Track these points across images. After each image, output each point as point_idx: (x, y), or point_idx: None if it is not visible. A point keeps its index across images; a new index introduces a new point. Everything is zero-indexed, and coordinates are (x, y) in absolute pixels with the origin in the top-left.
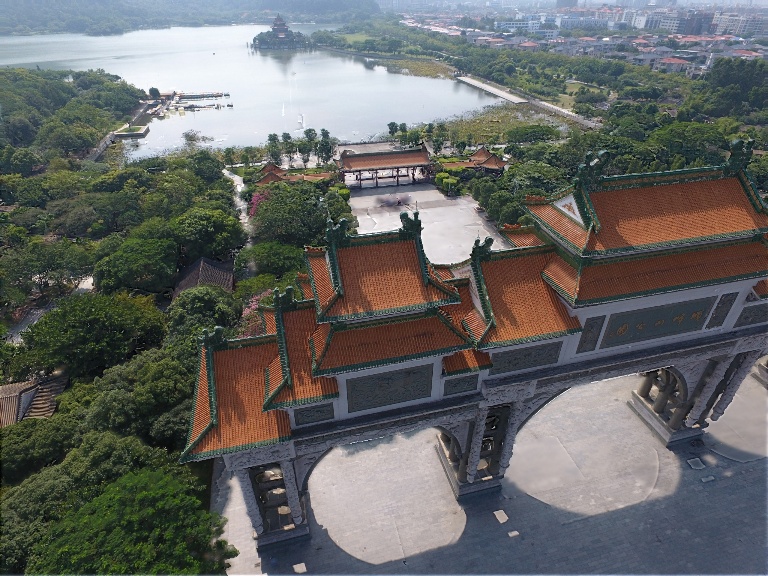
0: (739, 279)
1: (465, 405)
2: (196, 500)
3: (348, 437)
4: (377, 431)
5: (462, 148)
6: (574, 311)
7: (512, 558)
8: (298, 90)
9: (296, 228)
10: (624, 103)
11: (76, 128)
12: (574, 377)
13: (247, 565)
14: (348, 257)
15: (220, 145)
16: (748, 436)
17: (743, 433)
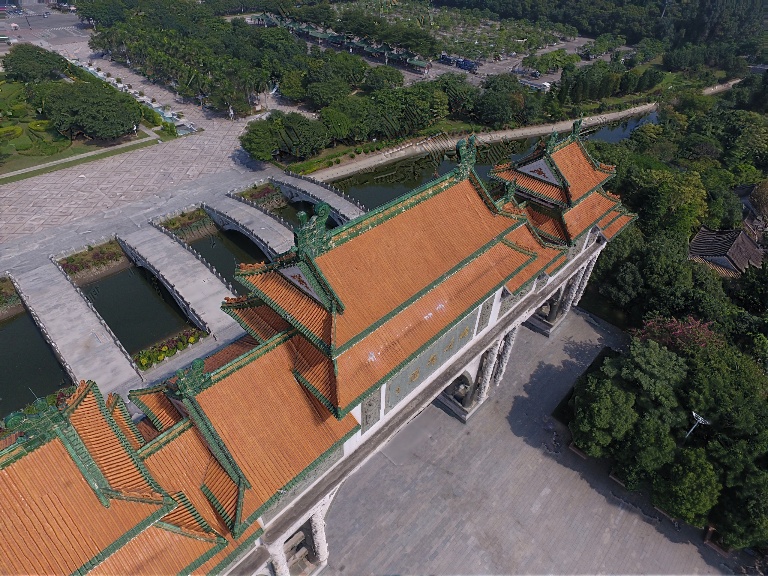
0: None
1: None
2: None
3: None
4: None
5: None
6: None
7: None
8: None
9: None
10: None
11: None
12: None
13: None
14: None
15: None
16: None
17: None
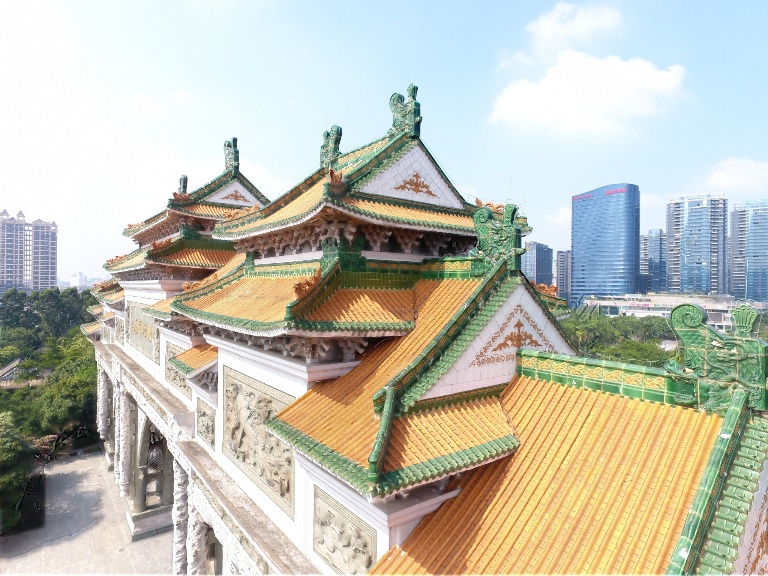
0: None
1: None
2: None
3: None
4: None
5: None
6: None
7: None
8: None
9: None
10: None
11: None
12: None
13: None
14: None
15: None
16: None
17: None
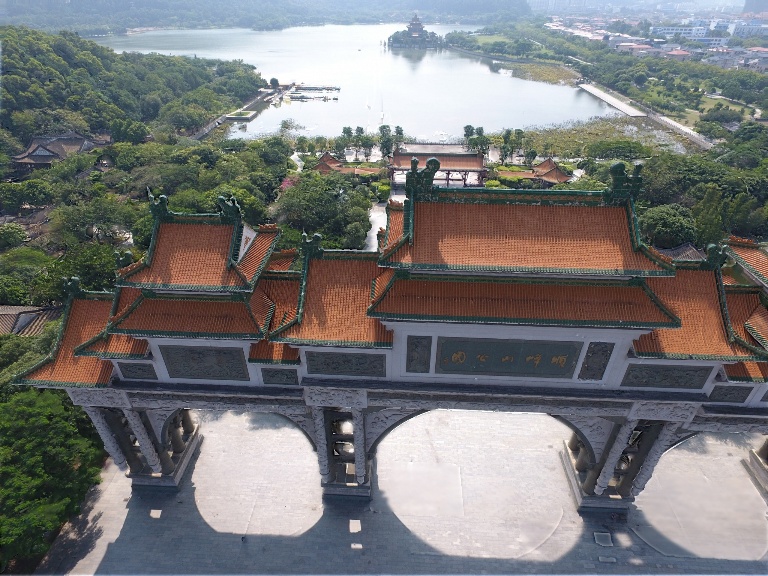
0: (591, 325)
1: (283, 397)
2: (70, 426)
3: (178, 401)
4: (205, 403)
5: (532, 158)
6: (384, 324)
7: (341, 568)
8: (382, 87)
9: (308, 215)
10: (756, 124)
11: (189, 108)
12: (414, 398)
13: (119, 497)
14: (170, 232)
15: (307, 134)
16: (691, 528)
17: (687, 523)
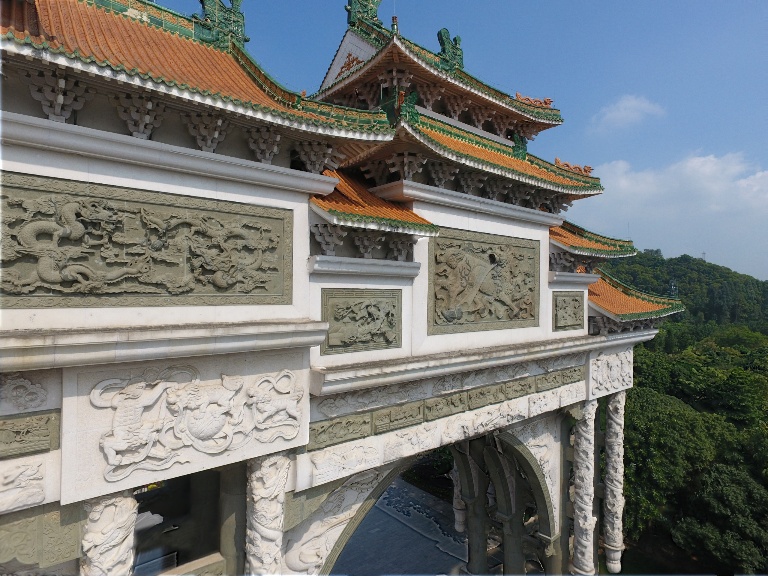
0: None
1: None
2: None
3: None
4: None
5: None
6: None
7: None
8: None
9: None
10: None
11: None
12: None
13: None
14: None
15: None
16: None
17: None
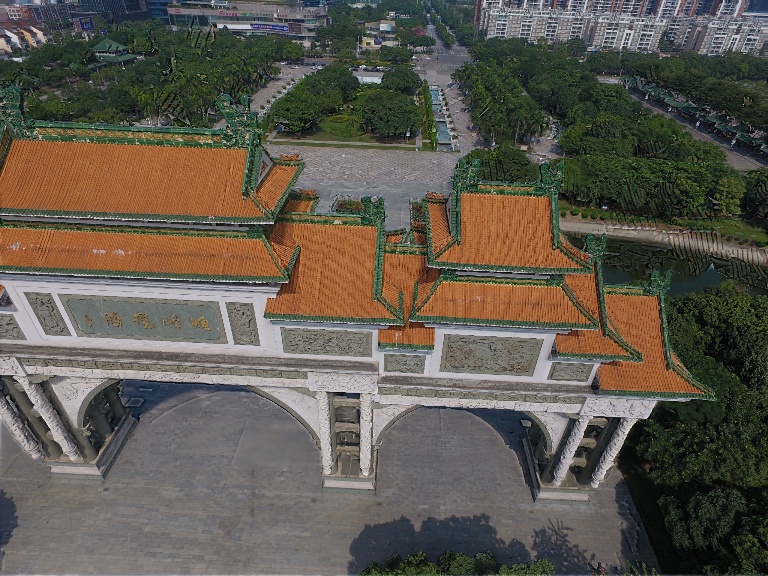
0: None
1: None
2: None
3: None
4: None
5: None
6: None
7: None
8: None
9: None
10: None
11: None
12: None
13: None
14: None
15: None
16: None
17: None
